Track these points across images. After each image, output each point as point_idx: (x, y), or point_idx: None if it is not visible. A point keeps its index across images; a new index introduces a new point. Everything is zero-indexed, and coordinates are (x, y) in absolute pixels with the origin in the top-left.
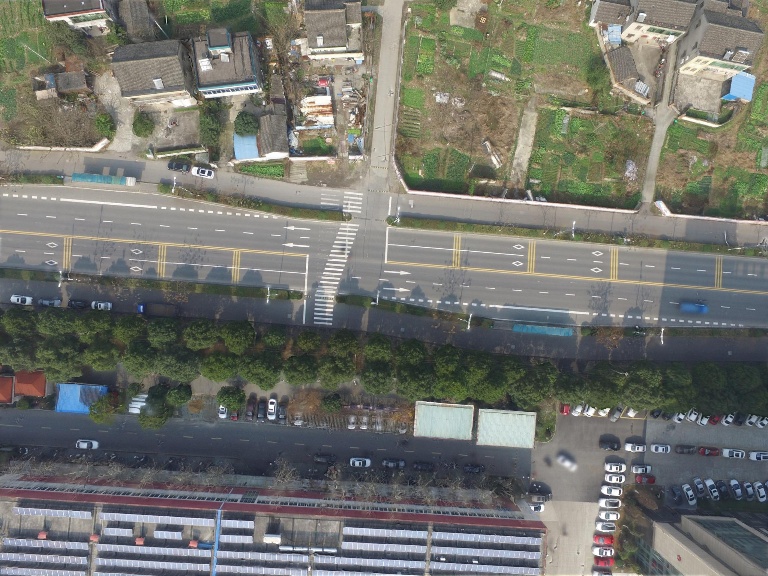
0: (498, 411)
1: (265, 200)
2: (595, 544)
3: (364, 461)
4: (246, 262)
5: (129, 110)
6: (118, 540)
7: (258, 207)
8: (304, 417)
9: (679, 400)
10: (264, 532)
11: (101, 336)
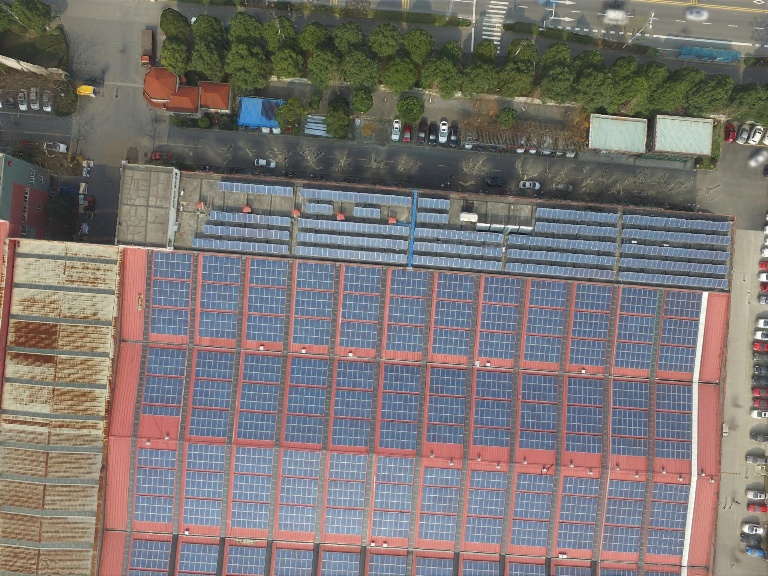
0: (676, 118)
1: None
2: (761, 271)
3: (534, 183)
4: None
5: None
6: (318, 219)
7: None
8: (478, 134)
9: None
10: (459, 214)
11: (288, 41)
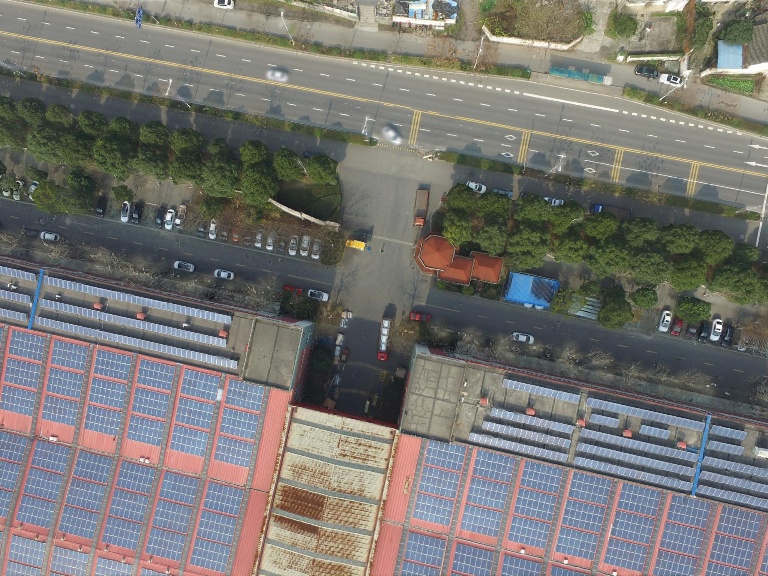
0: None
1: (732, 115)
2: None
3: None
4: (704, 176)
5: (604, 11)
6: (600, 429)
7: (726, 121)
8: (759, 341)
9: None
10: (752, 446)
11: (576, 228)
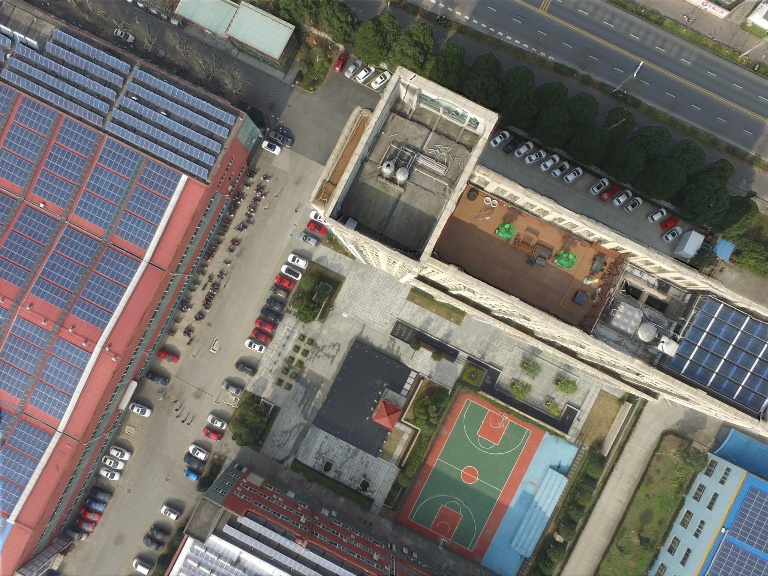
0: (259, 10)
1: None
2: None
3: (128, 35)
4: None
5: None
6: None
7: None
8: None
9: (438, 65)
10: None
11: None
